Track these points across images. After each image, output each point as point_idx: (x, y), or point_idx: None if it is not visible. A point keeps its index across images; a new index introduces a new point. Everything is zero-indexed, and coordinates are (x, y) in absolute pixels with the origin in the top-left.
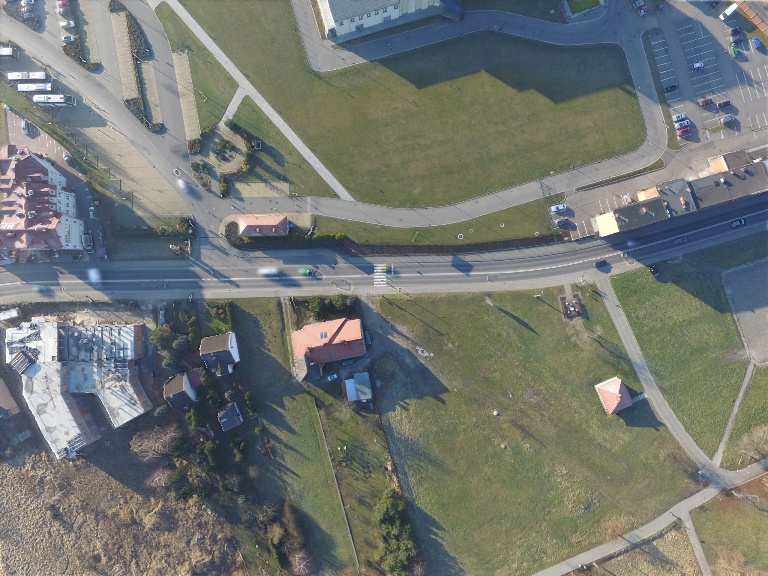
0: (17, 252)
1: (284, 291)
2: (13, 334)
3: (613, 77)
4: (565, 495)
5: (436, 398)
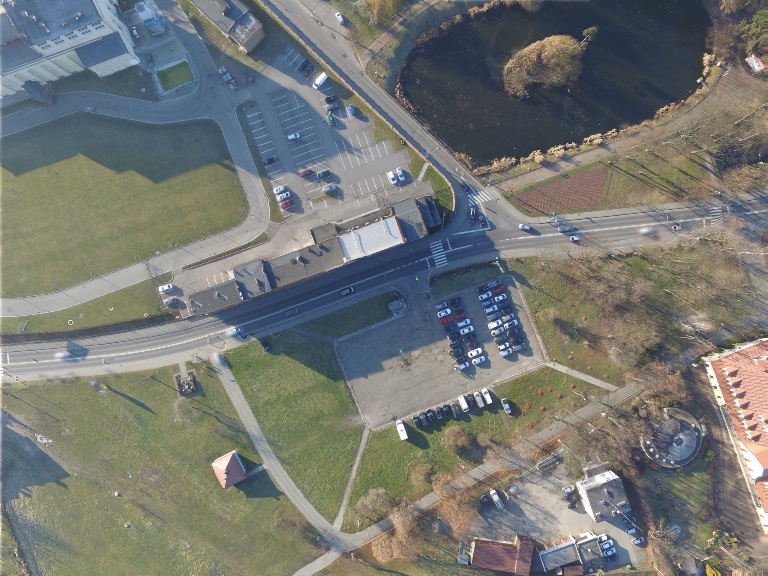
0: None
1: None
2: None
3: (210, 153)
4: (190, 568)
5: (58, 483)
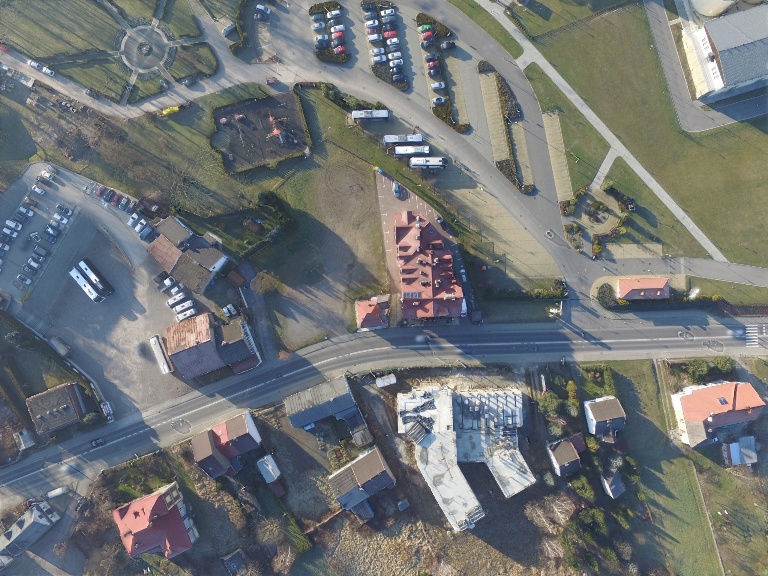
0: (389, 316)
1: (656, 353)
2: (406, 403)
3: None
4: None
5: None
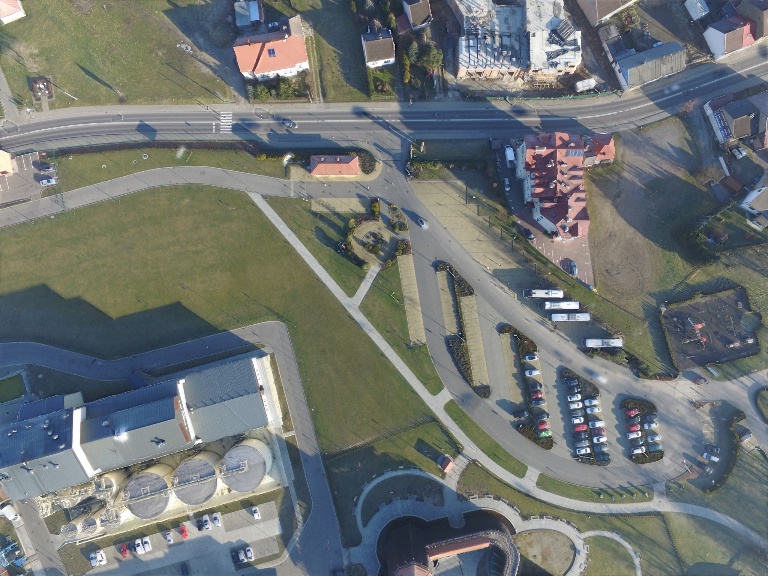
0: None
1: (320, 109)
2: (574, 58)
3: None
4: None
5: (176, 5)
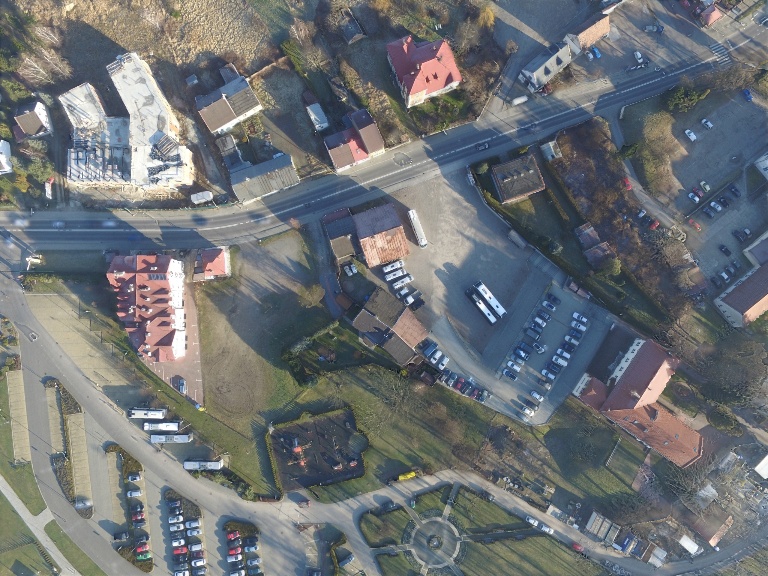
0: None
1: None
2: (176, 174)
3: None
4: None
5: None
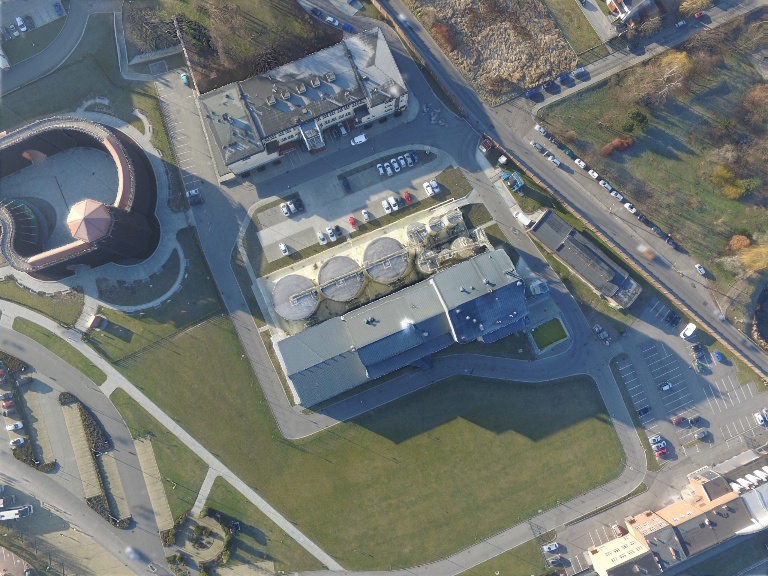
0: None
1: None
2: None
3: (587, 408)
4: None
5: None
